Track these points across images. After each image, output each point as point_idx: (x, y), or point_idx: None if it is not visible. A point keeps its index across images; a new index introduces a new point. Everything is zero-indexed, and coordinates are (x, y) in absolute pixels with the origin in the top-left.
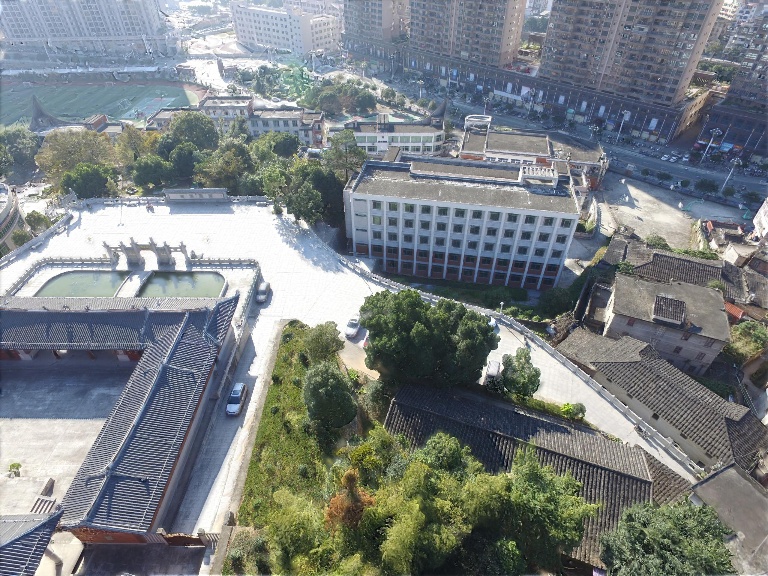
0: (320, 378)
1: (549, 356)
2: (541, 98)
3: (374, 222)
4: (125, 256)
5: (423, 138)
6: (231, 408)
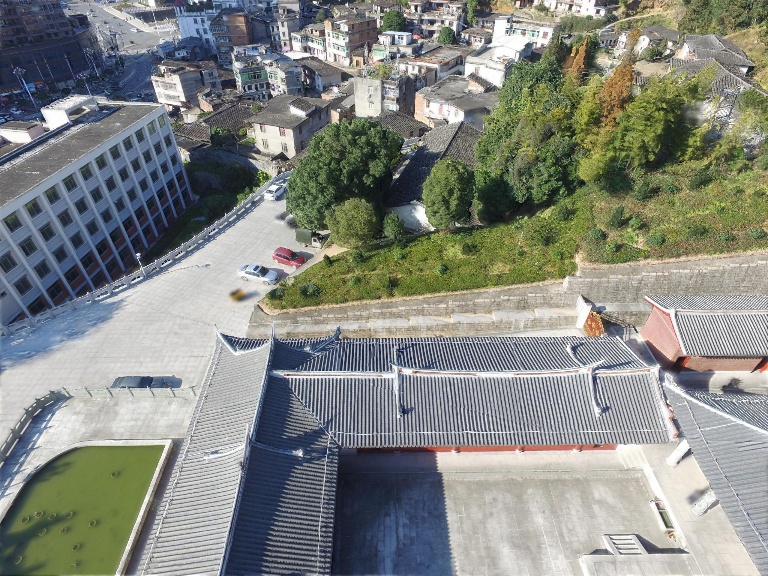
0: (458, 165)
1: None
2: None
3: (4, 270)
4: None
5: None
6: None
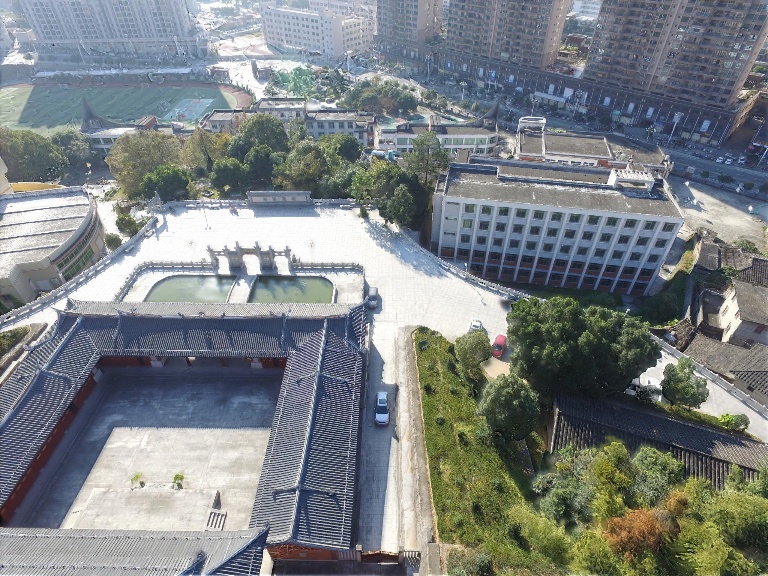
0: (511, 389)
1: None
2: (585, 100)
3: (464, 226)
4: (226, 260)
5: (477, 140)
6: (380, 418)
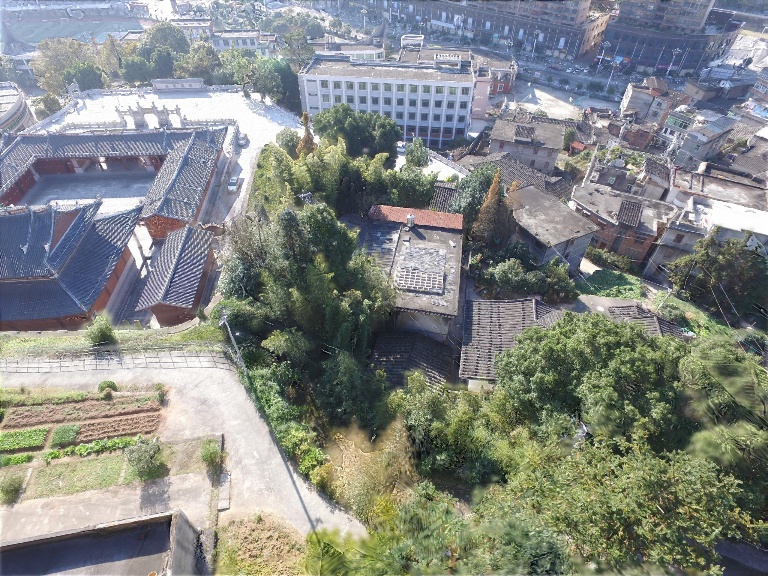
0: (289, 138)
1: (444, 165)
2: (471, 25)
3: (323, 100)
4: None
5: (366, 56)
6: (231, 188)
